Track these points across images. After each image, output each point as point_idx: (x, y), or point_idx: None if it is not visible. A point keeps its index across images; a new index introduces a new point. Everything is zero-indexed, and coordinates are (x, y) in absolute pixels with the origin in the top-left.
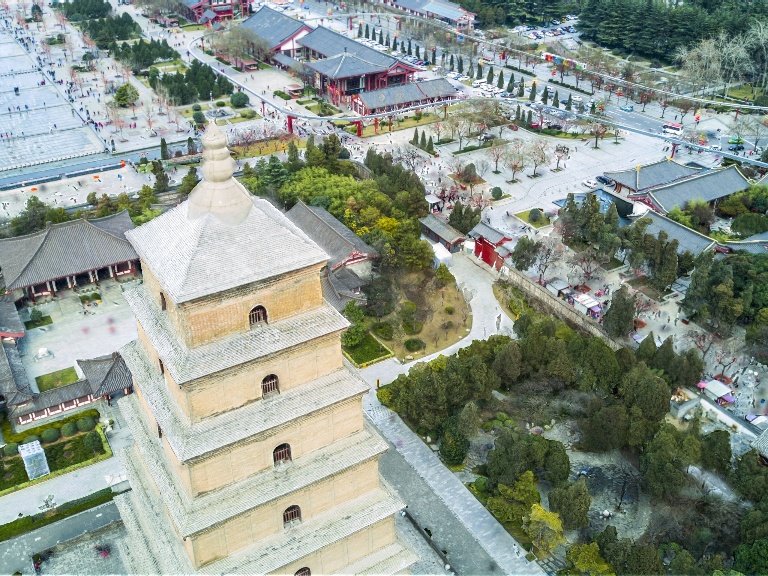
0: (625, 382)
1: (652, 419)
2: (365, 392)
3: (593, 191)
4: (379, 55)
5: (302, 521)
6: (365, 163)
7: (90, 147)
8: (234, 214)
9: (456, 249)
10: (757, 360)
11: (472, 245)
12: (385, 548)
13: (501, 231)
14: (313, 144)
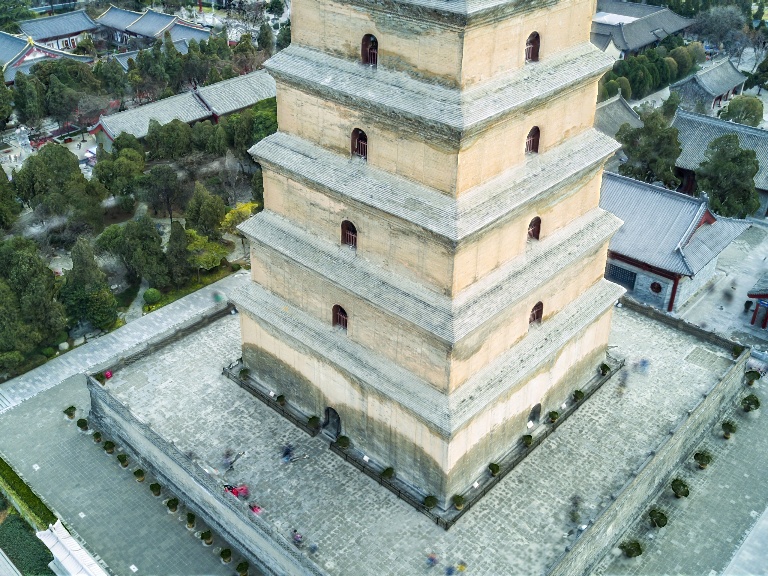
0: (36, 172)
1: None
2: None
3: None
4: None
5: None
6: None
7: None
8: None
9: None
10: None
11: None
12: None
13: None
14: None
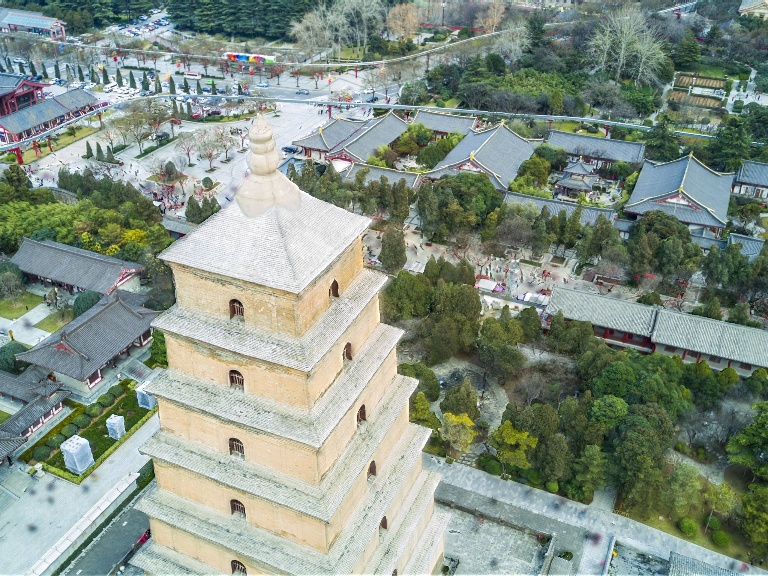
0: (442, 298)
1: (472, 320)
2: None
3: (287, 161)
4: None
5: (376, 475)
6: (60, 187)
7: None
8: (294, 200)
9: None
10: (495, 256)
11: None
12: (418, 477)
13: None
14: None
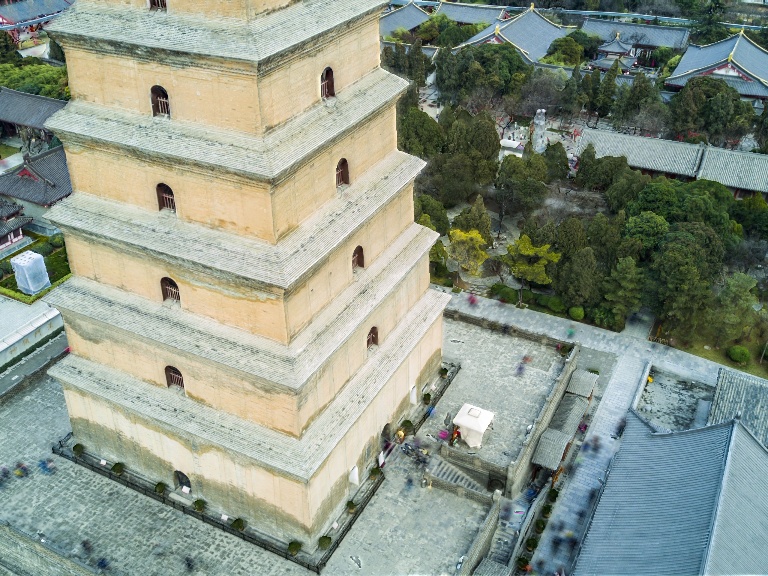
0: (455, 135)
1: (490, 160)
2: (384, 6)
3: None
4: None
5: (349, 184)
6: (51, 57)
7: None
8: None
9: None
10: (519, 125)
11: None
12: (409, 228)
13: None
14: None
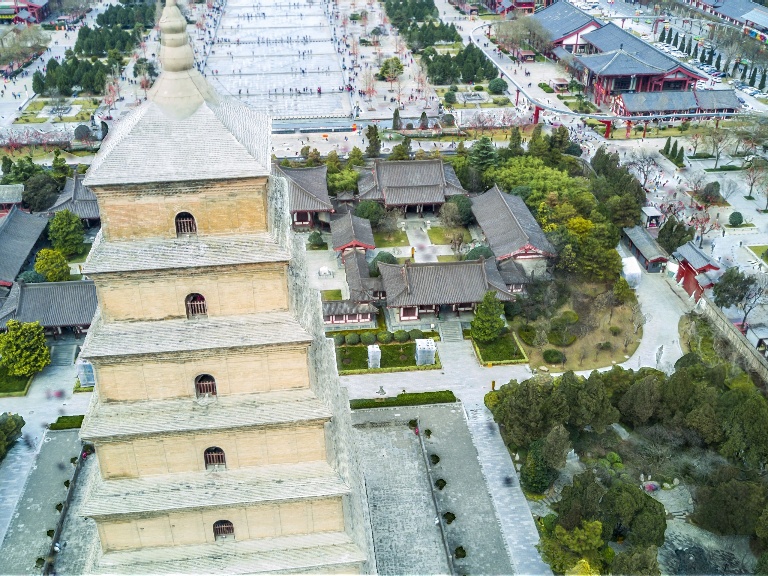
0: None
1: None
2: (307, 343)
3: None
4: (661, 57)
5: (227, 468)
6: (591, 162)
7: (339, 111)
8: (177, 108)
9: (655, 269)
10: None
11: (675, 268)
12: (330, 533)
13: (708, 256)
14: (539, 134)
